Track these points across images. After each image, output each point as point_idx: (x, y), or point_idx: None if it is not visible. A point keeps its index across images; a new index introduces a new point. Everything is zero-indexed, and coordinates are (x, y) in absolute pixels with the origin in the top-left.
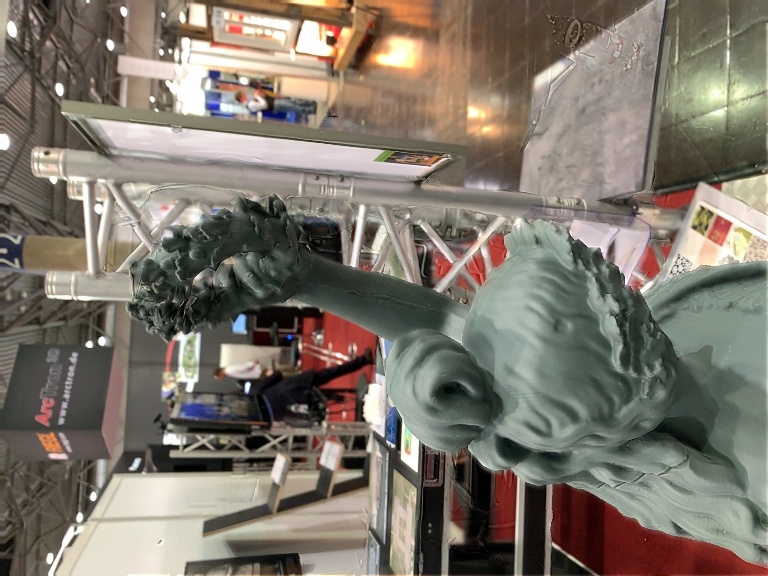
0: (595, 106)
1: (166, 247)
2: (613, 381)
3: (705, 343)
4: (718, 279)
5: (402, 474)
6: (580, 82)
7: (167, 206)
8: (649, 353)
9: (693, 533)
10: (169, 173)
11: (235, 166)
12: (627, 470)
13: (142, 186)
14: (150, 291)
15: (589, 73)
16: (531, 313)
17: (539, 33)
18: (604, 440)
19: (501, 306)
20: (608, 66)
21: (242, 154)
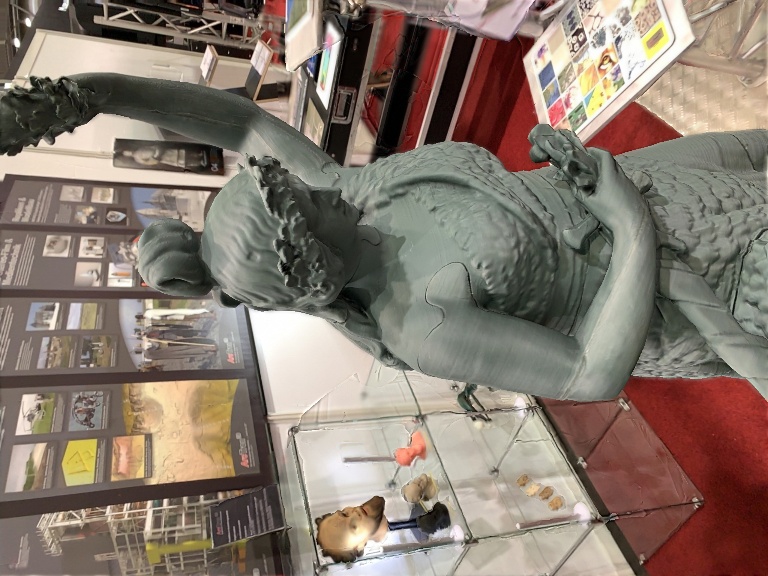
0: None
1: None
2: (289, 289)
3: (404, 234)
4: (441, 179)
5: (315, 105)
6: None
7: None
8: (313, 279)
9: None
10: None
11: None
12: None
13: None
14: None
15: None
16: (234, 243)
17: None
18: None
19: (219, 227)
20: None
21: None
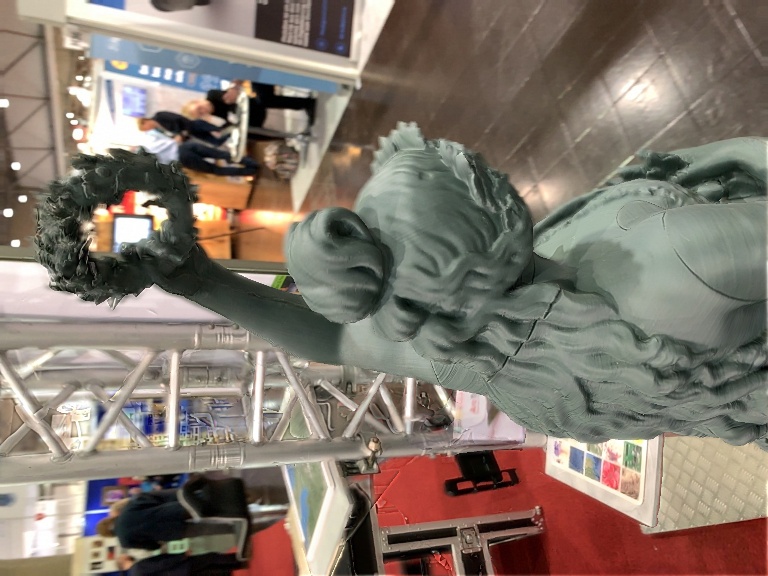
0: None
1: (73, 164)
2: (477, 215)
3: (557, 247)
4: (555, 218)
5: None
6: None
7: (54, 390)
8: (499, 190)
9: (594, 377)
10: (59, 334)
11: (129, 324)
12: (518, 323)
13: (28, 354)
14: (56, 209)
15: None
16: (399, 174)
17: None
18: (487, 279)
19: (375, 183)
20: None
21: (136, 306)
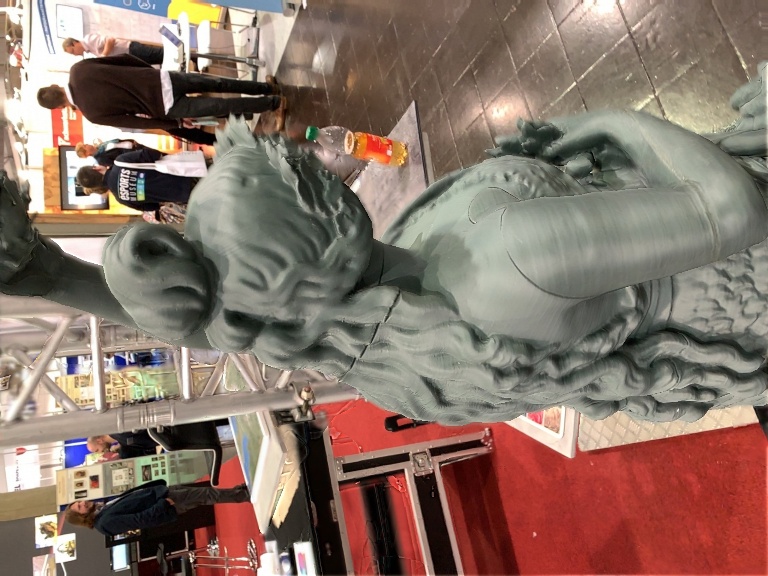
0: (388, 201)
1: None
2: (306, 222)
3: (418, 234)
4: (426, 197)
5: None
6: (373, 188)
7: None
8: (330, 193)
9: (437, 377)
10: None
11: None
12: (360, 327)
13: None
14: None
15: (378, 179)
16: (222, 180)
17: (321, 145)
18: (320, 287)
19: (201, 188)
20: (388, 167)
21: None
